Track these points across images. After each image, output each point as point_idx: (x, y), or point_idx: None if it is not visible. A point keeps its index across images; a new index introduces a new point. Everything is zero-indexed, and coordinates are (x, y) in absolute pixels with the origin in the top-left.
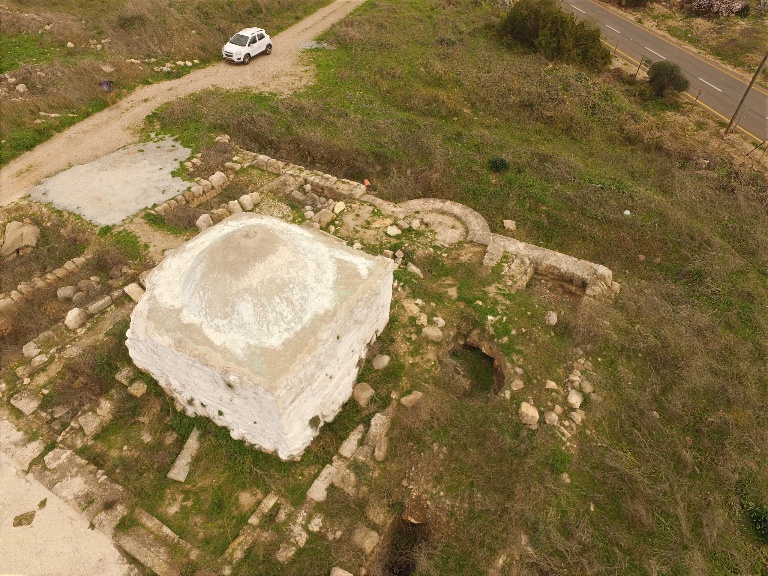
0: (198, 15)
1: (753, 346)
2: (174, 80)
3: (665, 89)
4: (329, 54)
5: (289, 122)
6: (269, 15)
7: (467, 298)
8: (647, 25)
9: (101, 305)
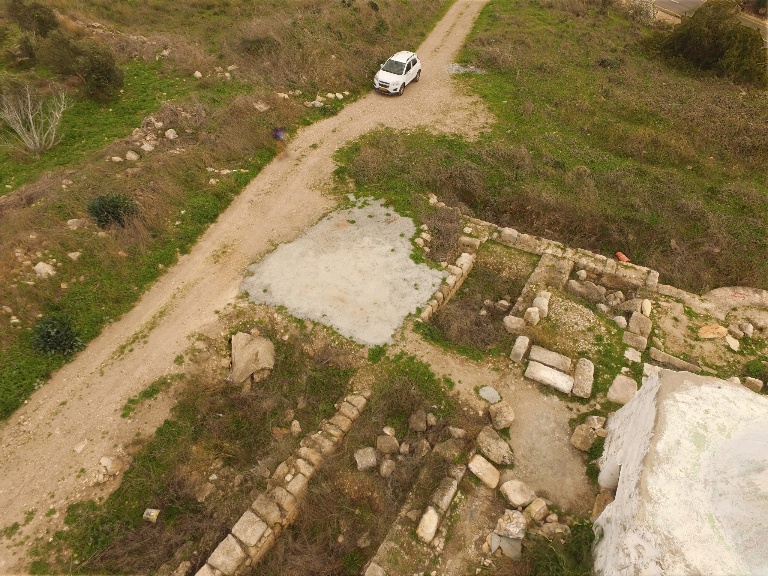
0: (330, 35)
1: None
2: (332, 118)
3: None
4: (486, 80)
5: (504, 176)
6: (395, 32)
7: None
8: None
9: (451, 497)
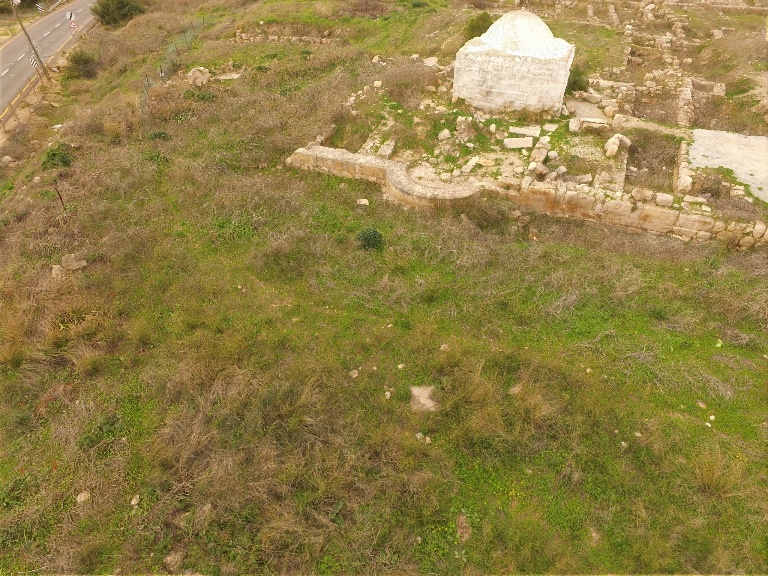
0: None
1: None
2: None
3: None
4: None
5: None
6: None
7: (407, 115)
8: None
9: None
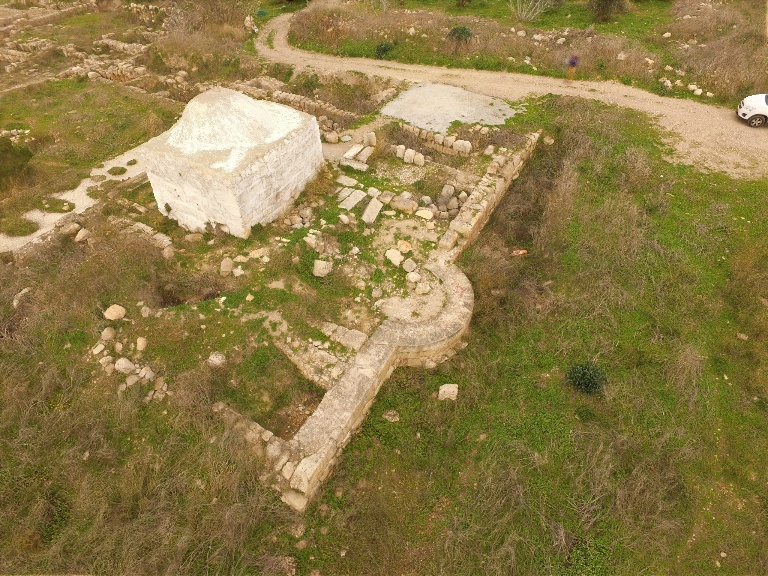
0: None
1: None
2: (653, 94)
3: None
4: None
5: None
6: None
7: (261, 291)
8: None
9: None
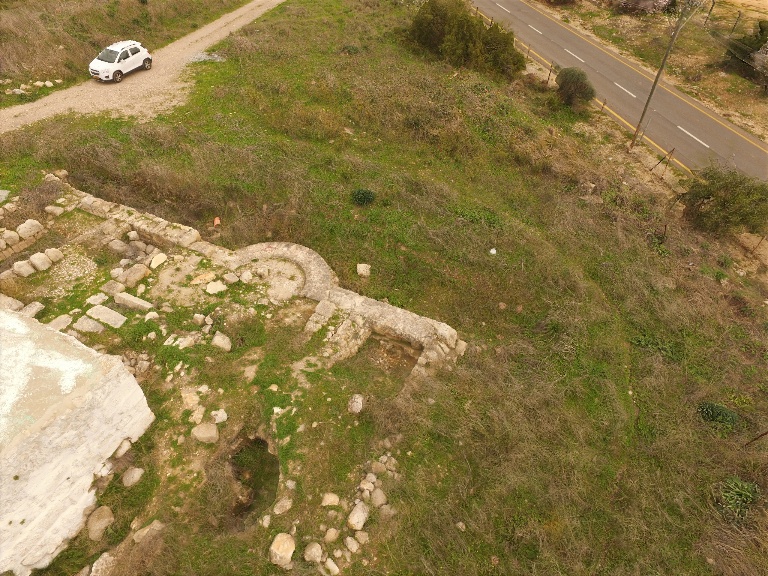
0: (71, 27)
1: (595, 424)
2: (26, 104)
3: (573, 97)
4: (215, 67)
5: (138, 153)
6: (160, 24)
7: (263, 381)
8: (573, 24)
9: None
